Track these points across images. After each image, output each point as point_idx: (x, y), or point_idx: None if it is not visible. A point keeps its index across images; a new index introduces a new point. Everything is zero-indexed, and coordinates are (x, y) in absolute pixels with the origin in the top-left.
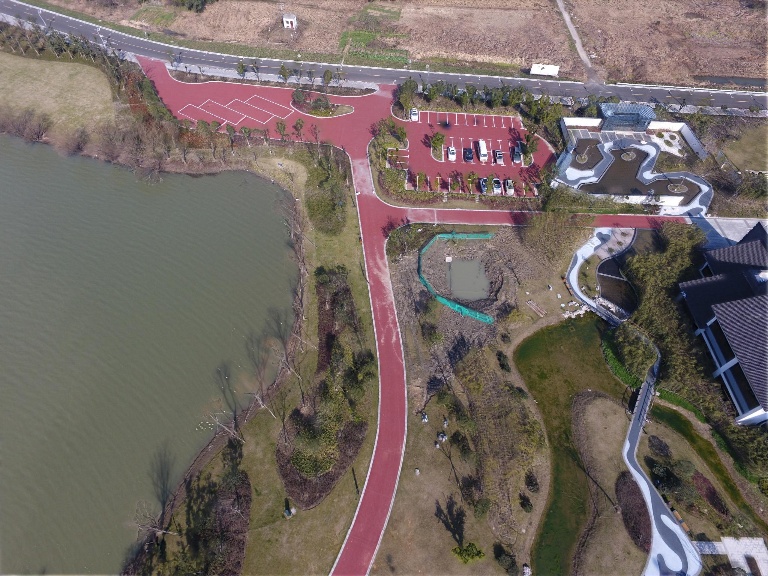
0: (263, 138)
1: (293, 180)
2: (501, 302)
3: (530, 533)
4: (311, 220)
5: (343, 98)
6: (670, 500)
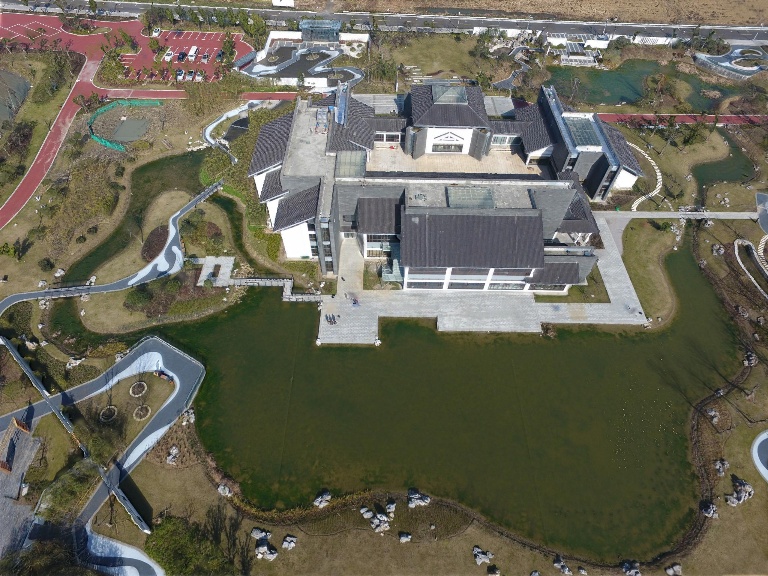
0: (25, 48)
1: (35, 75)
2: None
3: (76, 255)
4: (32, 97)
5: (107, 23)
6: (184, 239)
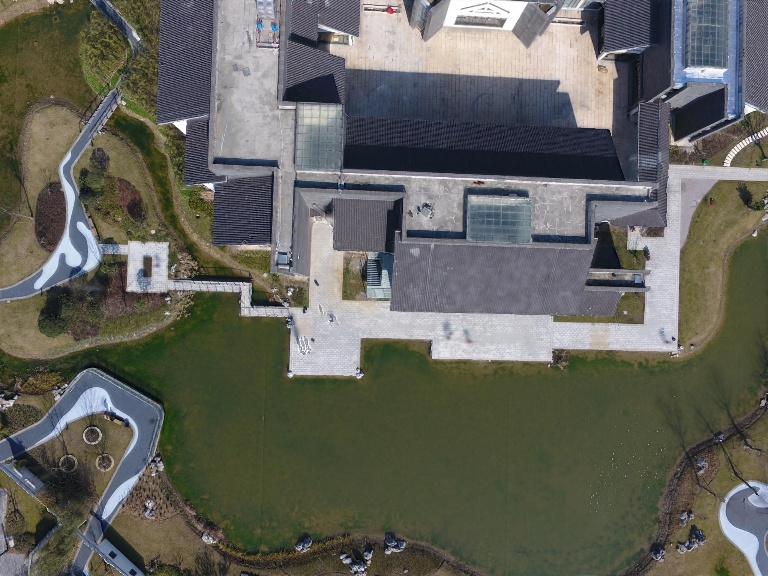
0: None
1: None
2: None
3: None
4: None
5: None
6: (90, 209)
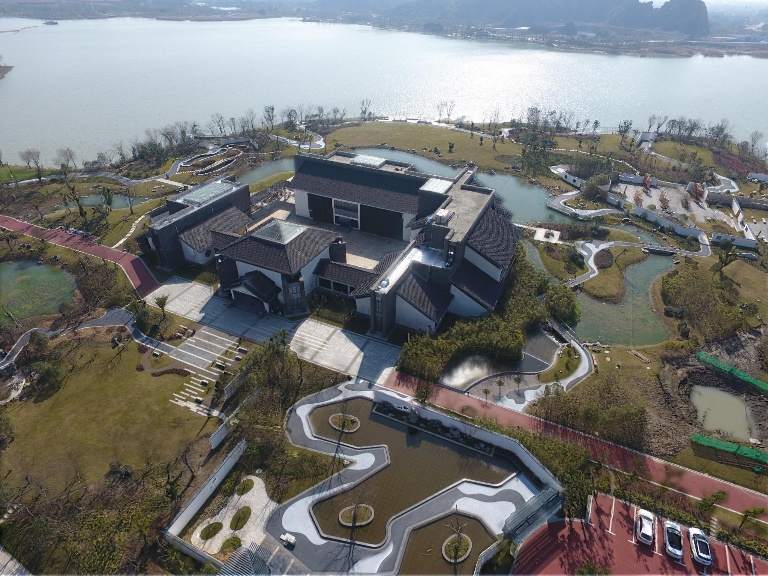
0: None
1: None
2: (683, 370)
3: None
4: None
5: None
6: None
